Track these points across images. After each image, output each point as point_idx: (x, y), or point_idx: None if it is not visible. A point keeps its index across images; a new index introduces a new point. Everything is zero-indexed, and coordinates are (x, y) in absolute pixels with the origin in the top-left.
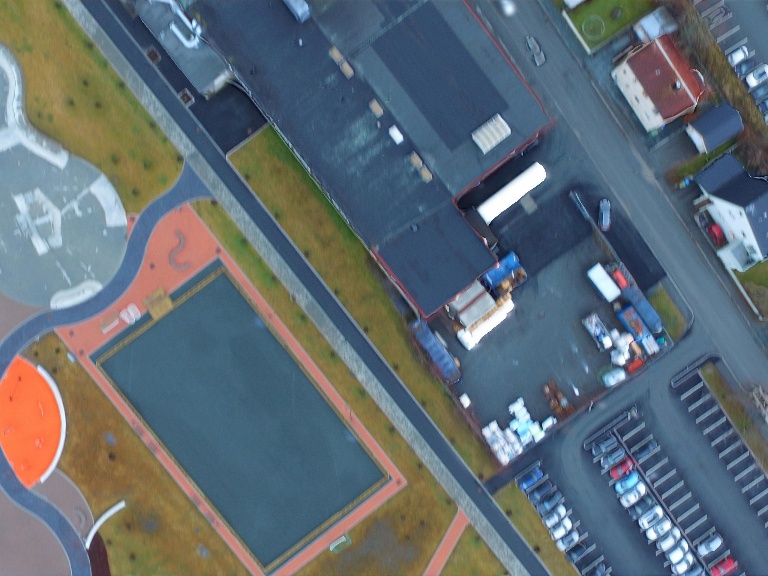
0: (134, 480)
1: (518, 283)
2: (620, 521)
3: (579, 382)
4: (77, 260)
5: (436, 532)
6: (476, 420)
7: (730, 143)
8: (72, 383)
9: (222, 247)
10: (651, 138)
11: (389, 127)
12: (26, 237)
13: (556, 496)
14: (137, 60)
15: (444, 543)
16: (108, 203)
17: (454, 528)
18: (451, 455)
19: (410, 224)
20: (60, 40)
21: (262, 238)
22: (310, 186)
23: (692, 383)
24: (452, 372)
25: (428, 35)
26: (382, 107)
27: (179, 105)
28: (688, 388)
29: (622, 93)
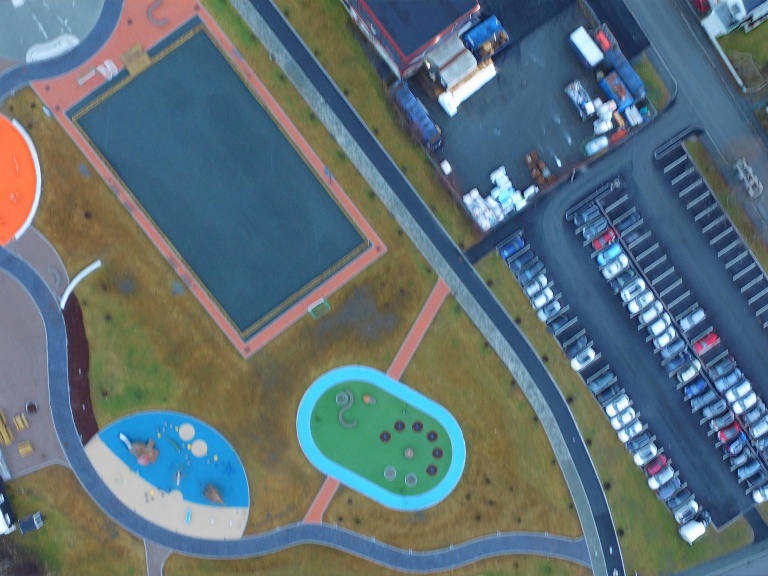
0: (110, 240)
1: (500, 46)
2: (602, 294)
3: (561, 153)
4: (53, 13)
5: (416, 300)
6: (457, 189)
7: None
8: (48, 139)
9: (201, 4)
10: None
11: None
12: None
13: (537, 265)
14: None
15: (424, 312)
16: None
17: (434, 297)
18: (432, 223)
19: None
20: None
21: None
22: None
23: (675, 155)
24: (433, 133)
25: None
26: None
27: None
28: (671, 161)
29: None
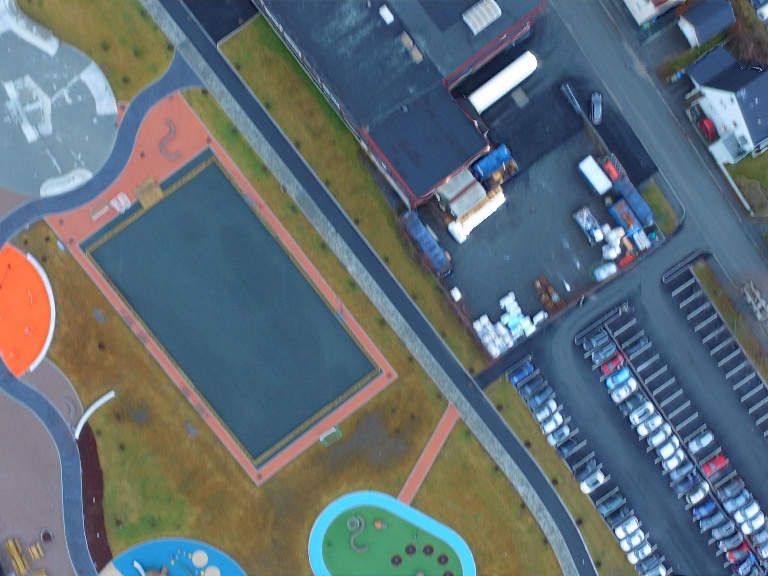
0: (124, 370)
1: (509, 175)
2: (611, 417)
3: (570, 277)
4: (67, 148)
5: (426, 426)
6: (467, 314)
7: (722, 37)
8: (62, 272)
9: (213, 137)
10: (643, 31)
11: (379, 7)
12: (16, 124)
13: (547, 390)
14: None
15: (434, 437)
16: (98, 90)
17: (445, 422)
18: (442, 349)
19: (400, 105)
20: None
21: (253, 128)
22: (301, 77)
23: (683, 279)
24: (443, 263)
25: None
26: None
27: None
28: (679, 284)
29: None
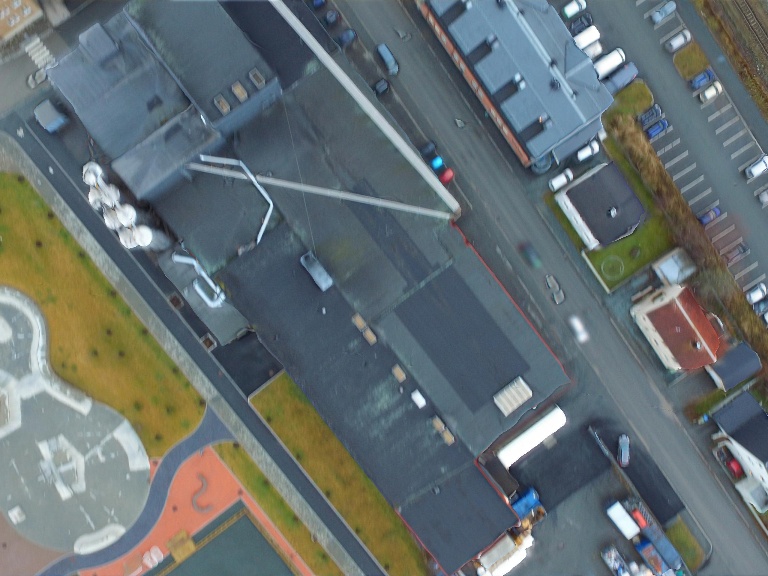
0: None
1: (538, 521)
2: None
3: None
4: (100, 504)
5: None
6: None
7: (748, 379)
8: None
9: (244, 489)
10: (670, 374)
11: (412, 392)
12: (50, 483)
13: None
14: (160, 306)
15: None
16: (131, 449)
17: None
18: None
19: (432, 486)
20: (84, 290)
21: (284, 479)
22: None
23: None
24: None
25: (450, 299)
26: (405, 372)
27: (201, 350)
28: None
29: (641, 330)
